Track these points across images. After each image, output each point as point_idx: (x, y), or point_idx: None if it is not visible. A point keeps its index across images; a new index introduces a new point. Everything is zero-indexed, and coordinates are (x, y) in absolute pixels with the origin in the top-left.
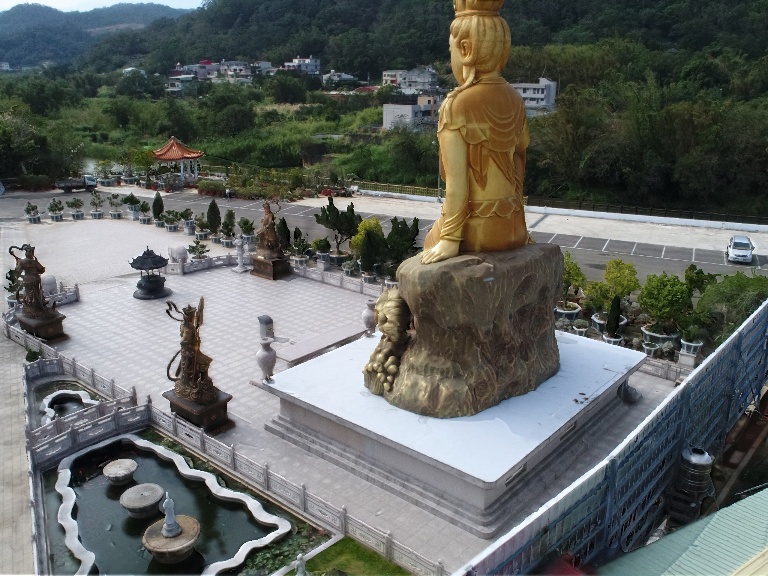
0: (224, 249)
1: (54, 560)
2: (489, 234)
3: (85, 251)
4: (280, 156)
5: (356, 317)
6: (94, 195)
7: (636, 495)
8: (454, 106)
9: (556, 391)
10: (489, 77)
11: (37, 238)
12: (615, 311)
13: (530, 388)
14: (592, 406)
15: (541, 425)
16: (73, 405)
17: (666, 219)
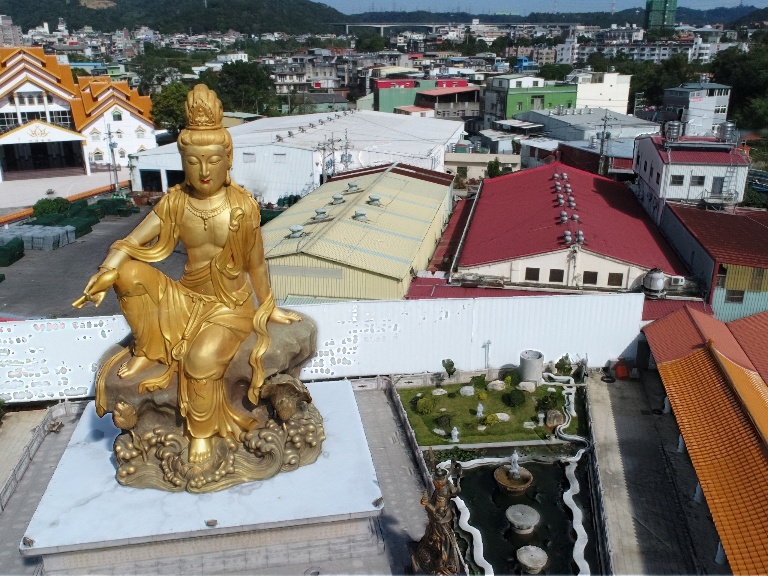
0: None
1: None
2: None
3: None
4: None
5: None
6: None
7: None
8: None
9: None
10: None
11: None
12: None
13: None
14: None
15: None
16: None
17: None
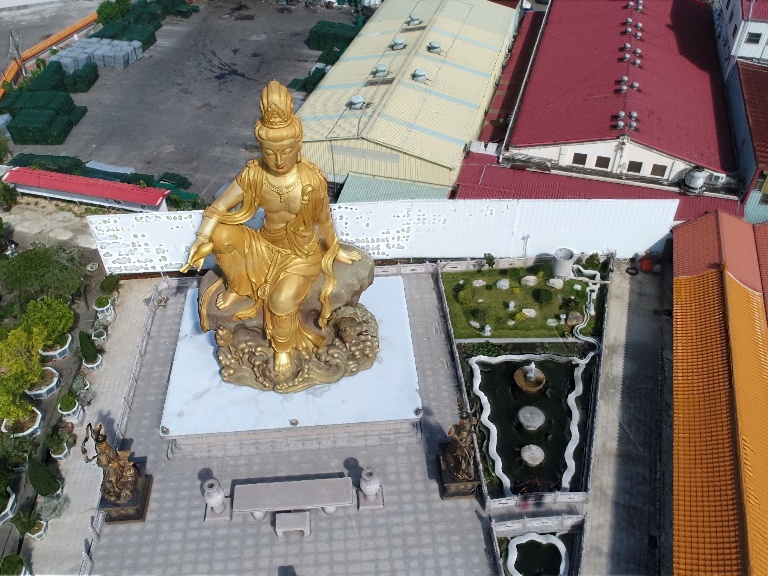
0: None
1: (587, 414)
2: None
3: None
4: None
5: (169, 573)
6: None
7: None
8: None
9: None
10: None
11: None
12: None
13: None
14: None
15: None
16: None
17: None
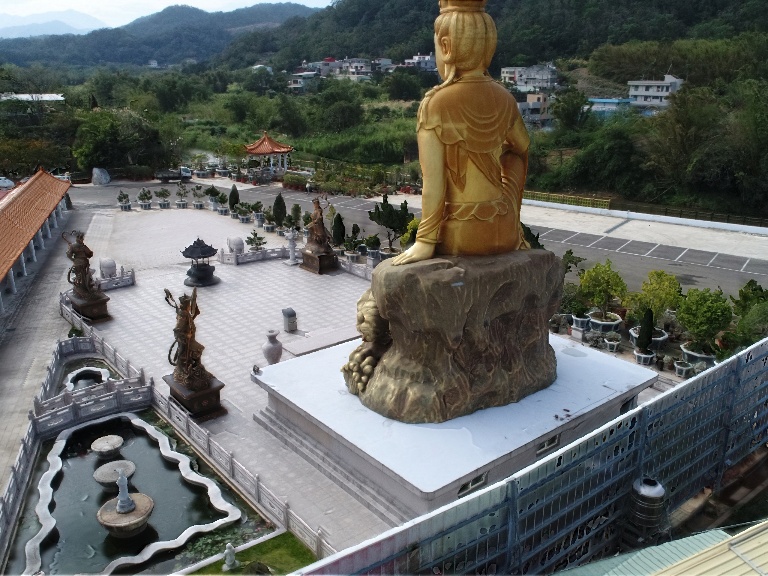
0: (286, 242)
1: (22, 522)
2: (467, 238)
3: (159, 238)
4: (382, 152)
5: None
6: (180, 186)
7: (566, 522)
8: (430, 105)
9: (540, 405)
10: (470, 75)
11: (122, 224)
12: (646, 325)
13: (512, 400)
14: (575, 424)
15: (507, 439)
16: (95, 381)
17: (761, 229)
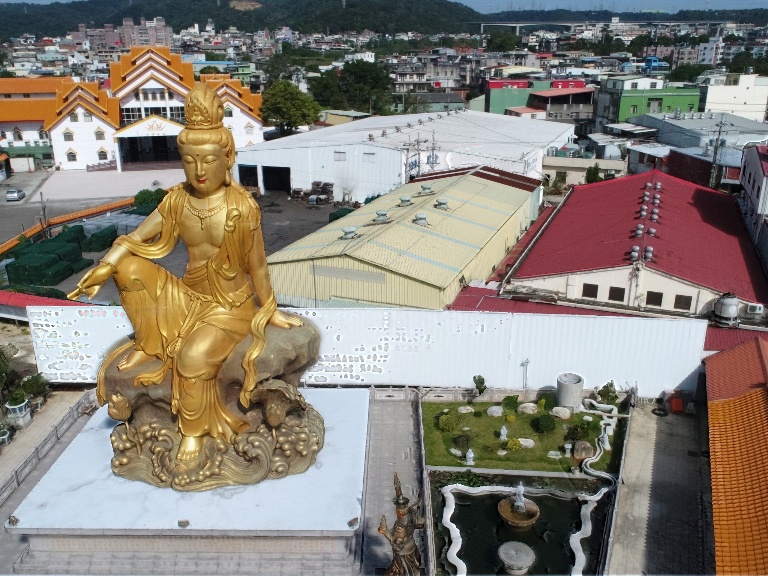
0: None
1: (597, 560)
2: None
3: None
4: None
5: None
6: None
7: None
8: None
9: None
10: None
11: None
12: None
13: None
14: None
15: None
16: None
17: None
